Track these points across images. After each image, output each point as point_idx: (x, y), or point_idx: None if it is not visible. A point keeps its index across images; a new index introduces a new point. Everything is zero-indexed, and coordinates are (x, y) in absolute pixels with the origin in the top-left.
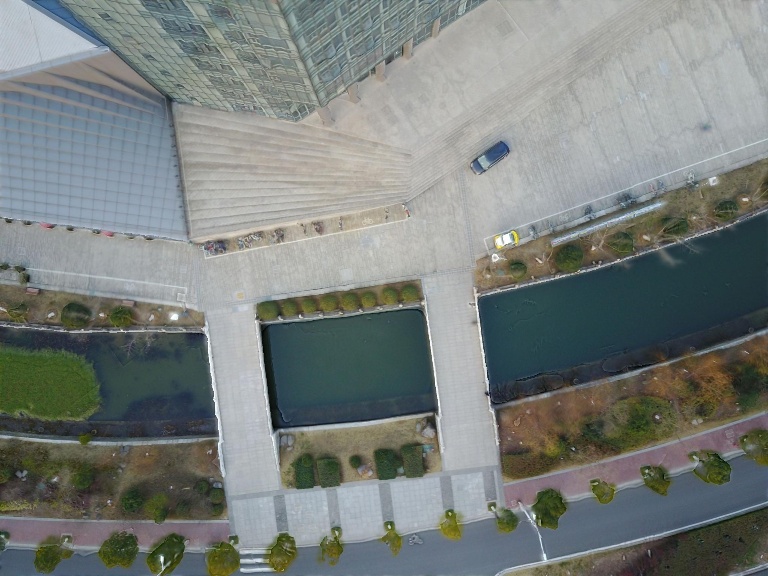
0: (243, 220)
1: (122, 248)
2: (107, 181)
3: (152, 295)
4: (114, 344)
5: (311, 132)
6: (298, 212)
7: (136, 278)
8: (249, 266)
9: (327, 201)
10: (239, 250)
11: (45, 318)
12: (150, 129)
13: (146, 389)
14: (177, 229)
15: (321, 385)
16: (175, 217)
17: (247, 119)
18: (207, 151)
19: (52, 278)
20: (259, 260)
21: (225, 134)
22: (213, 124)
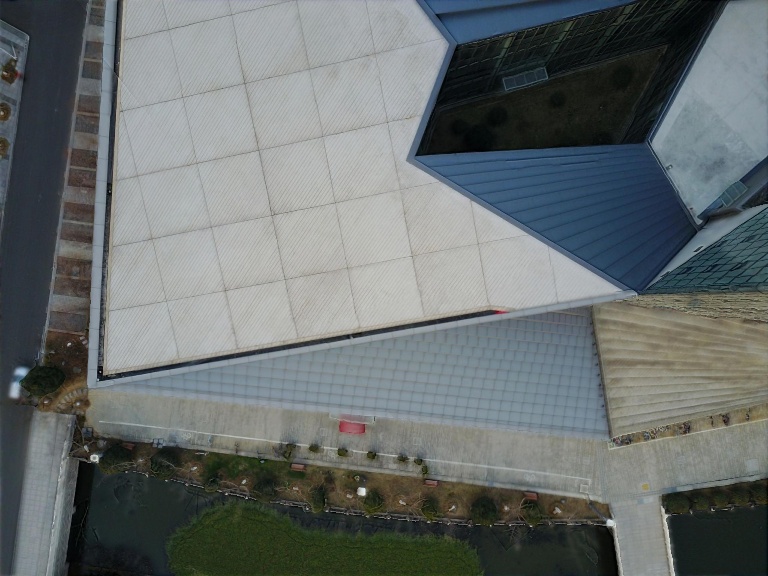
0: (660, 416)
1: (521, 438)
2: (537, 384)
3: (553, 486)
4: (496, 528)
5: (728, 328)
6: (712, 406)
7: (536, 469)
8: (654, 457)
9: (740, 395)
10: (644, 441)
11: (445, 511)
12: (579, 330)
13: (529, 574)
14: (600, 429)
15: (714, 571)
16: (598, 416)
17: (665, 315)
18: (625, 348)
19: (449, 469)
20: (664, 451)
21: (642, 330)
22: (630, 320)
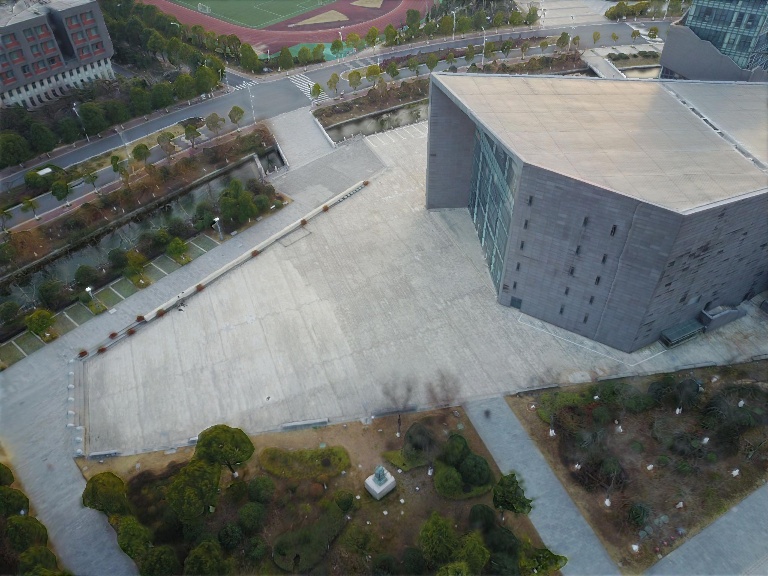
0: None
1: None
2: None
3: None
4: None
5: None
6: None
7: None
8: None
9: None
10: None
11: None
12: None
13: None
14: None
15: None
16: None
17: None
18: None
19: None
20: None
21: None
22: None
